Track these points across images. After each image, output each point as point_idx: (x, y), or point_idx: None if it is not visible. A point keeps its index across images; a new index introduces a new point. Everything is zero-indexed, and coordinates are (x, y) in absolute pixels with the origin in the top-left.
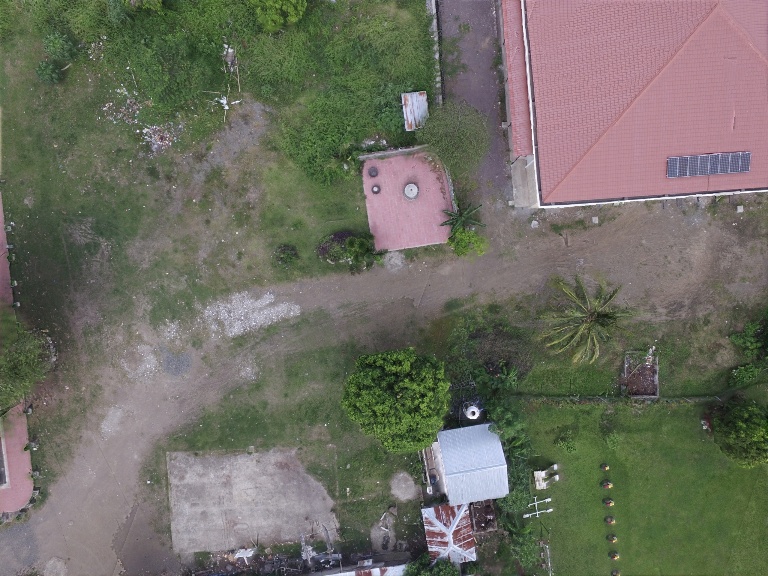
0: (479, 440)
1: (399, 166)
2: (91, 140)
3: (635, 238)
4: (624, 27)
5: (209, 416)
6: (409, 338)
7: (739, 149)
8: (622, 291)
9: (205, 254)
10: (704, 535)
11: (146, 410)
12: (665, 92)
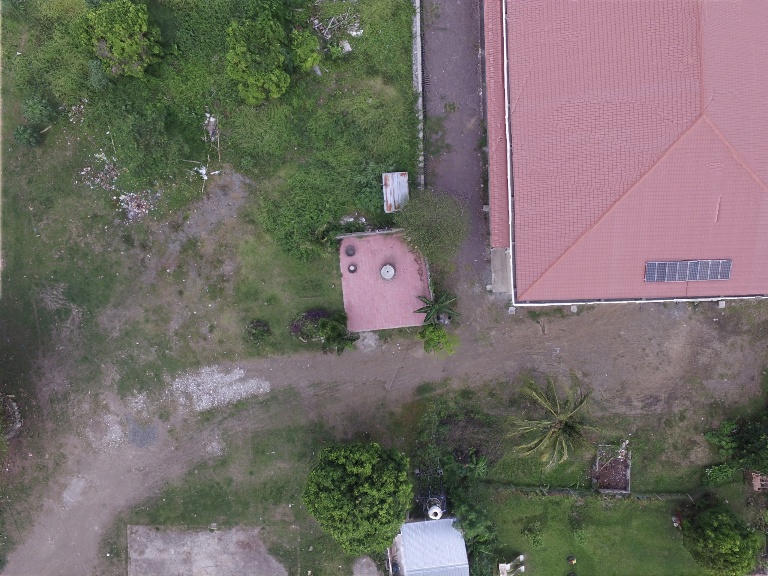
0: (442, 536)
1: (377, 245)
2: (67, 204)
3: (613, 329)
4: (608, 125)
5: (172, 490)
6: (379, 421)
7: (719, 257)
8: (598, 382)
9: (176, 325)
10: None
11: (109, 481)
12: (646, 198)
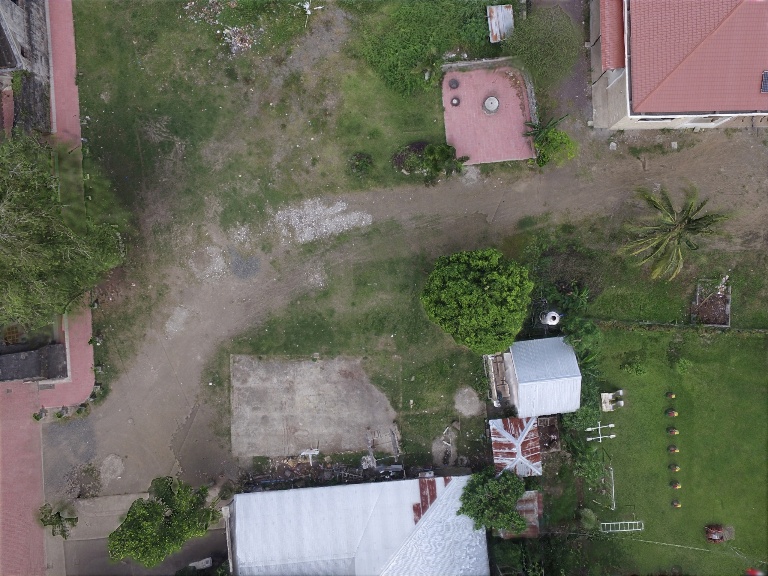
0: (553, 352)
1: (479, 80)
2: (171, 38)
3: (714, 166)
4: None
5: (275, 321)
6: None
7: None
8: None
9: (279, 158)
10: (767, 470)
11: (212, 311)
12: (767, 2)
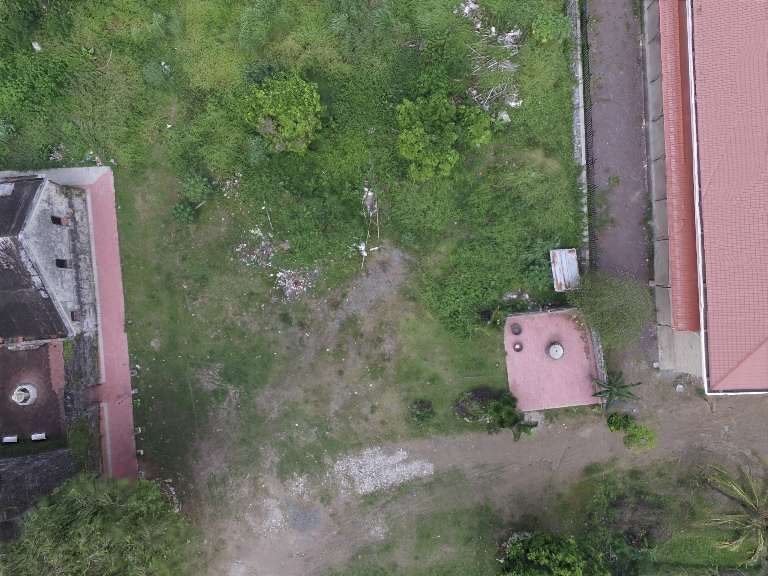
0: None
1: (542, 322)
2: (223, 282)
3: None
4: None
5: None
6: (546, 503)
7: None
8: (767, 461)
9: (337, 406)
10: None
11: (270, 567)
12: None
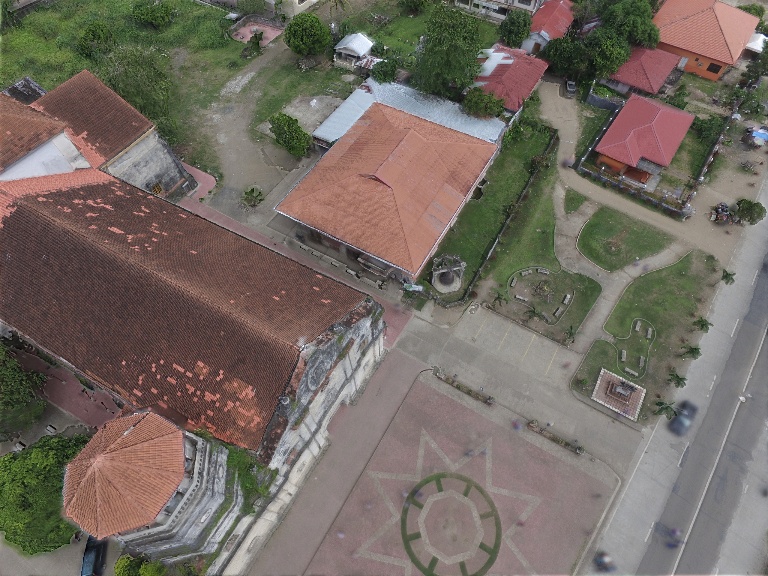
0: None
1: (243, 31)
2: None
3: None
4: None
5: (257, 112)
6: None
7: None
8: None
9: (202, 84)
10: None
11: (231, 127)
12: None
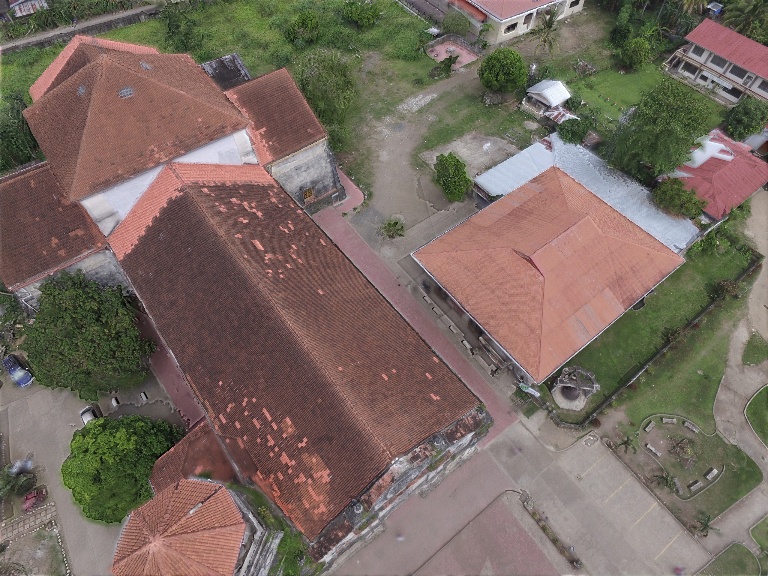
0: None
1: (439, 49)
2: None
3: None
4: None
5: (426, 137)
6: None
7: None
8: None
9: (383, 94)
10: None
11: (396, 147)
12: None
